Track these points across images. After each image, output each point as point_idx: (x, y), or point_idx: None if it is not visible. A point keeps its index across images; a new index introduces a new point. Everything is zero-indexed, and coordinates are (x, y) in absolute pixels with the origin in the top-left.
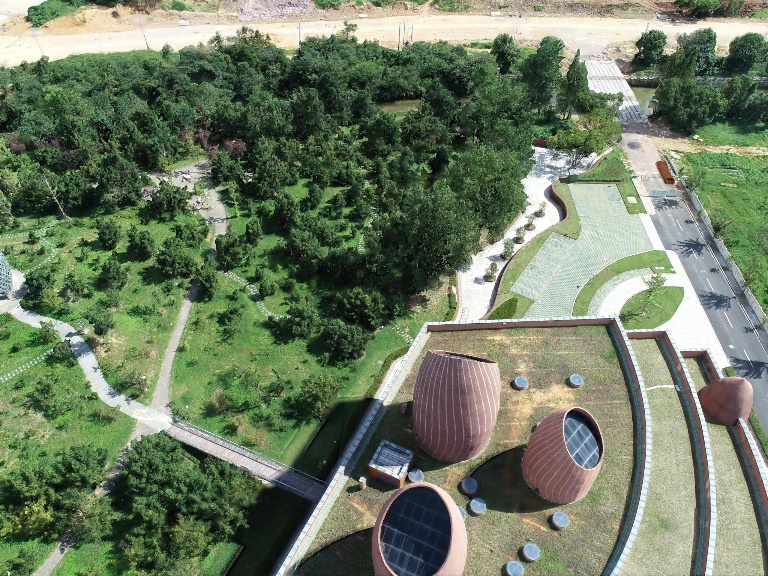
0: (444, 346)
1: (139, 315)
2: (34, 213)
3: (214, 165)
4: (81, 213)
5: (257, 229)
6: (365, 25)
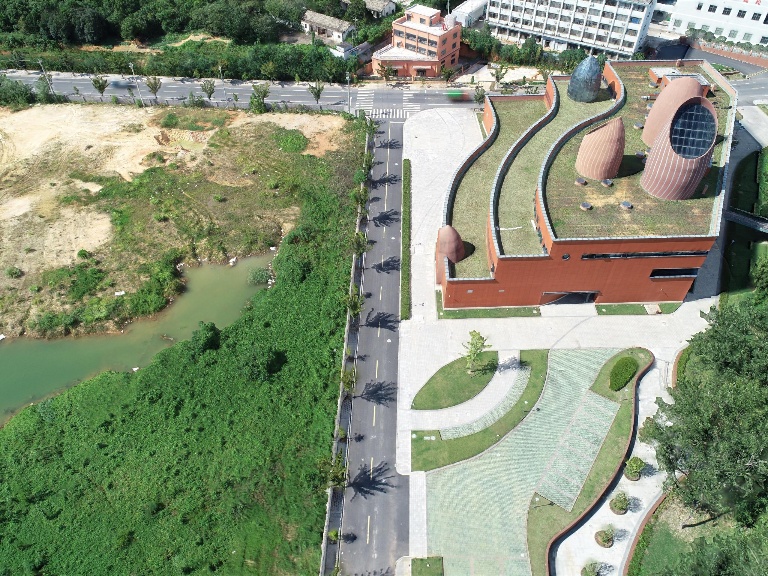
0: (693, 230)
1: None
2: None
3: None
4: None
5: None
6: None
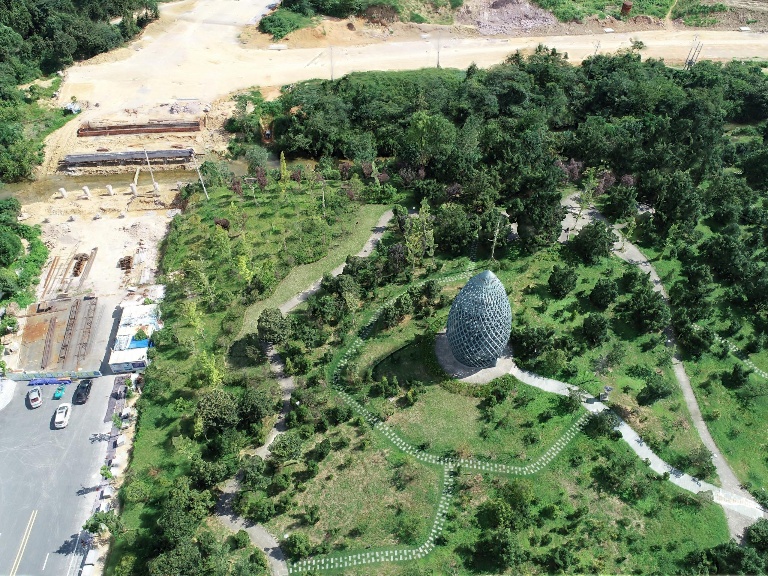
0: None
1: (639, 376)
2: (440, 253)
3: (607, 200)
4: (496, 254)
5: (711, 276)
6: (617, 40)
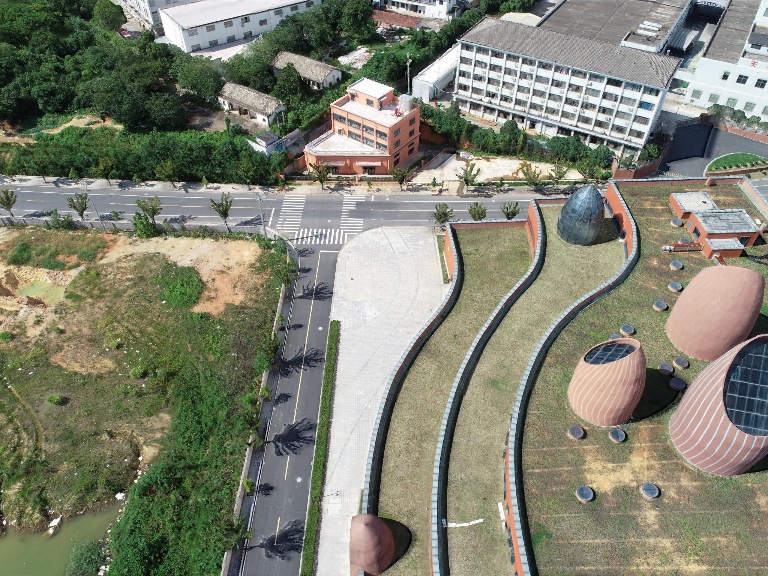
0: (762, 552)
1: None
2: None
3: None
4: None
5: None
6: None
